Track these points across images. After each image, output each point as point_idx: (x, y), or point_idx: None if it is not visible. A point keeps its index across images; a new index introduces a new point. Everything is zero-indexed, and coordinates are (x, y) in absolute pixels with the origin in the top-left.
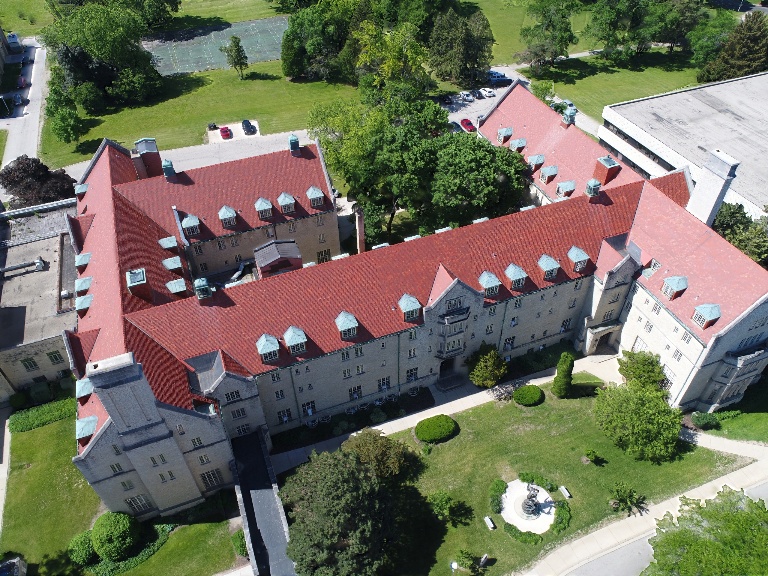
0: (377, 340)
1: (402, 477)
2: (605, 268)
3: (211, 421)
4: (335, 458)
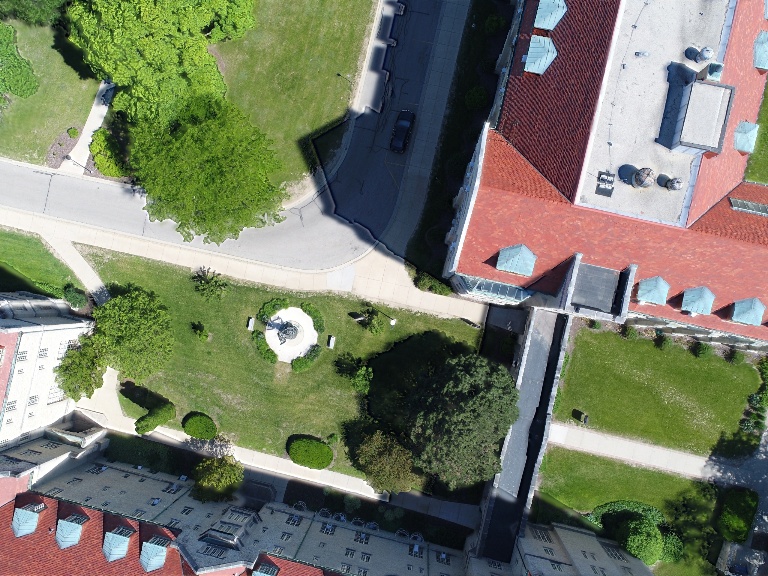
0: (322, 567)
1: (372, 429)
2: (11, 486)
3: (542, 575)
4: (443, 463)
